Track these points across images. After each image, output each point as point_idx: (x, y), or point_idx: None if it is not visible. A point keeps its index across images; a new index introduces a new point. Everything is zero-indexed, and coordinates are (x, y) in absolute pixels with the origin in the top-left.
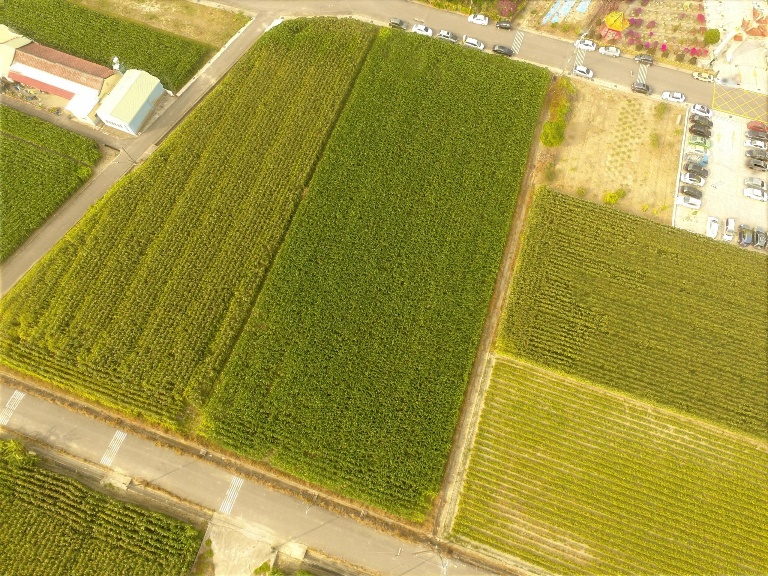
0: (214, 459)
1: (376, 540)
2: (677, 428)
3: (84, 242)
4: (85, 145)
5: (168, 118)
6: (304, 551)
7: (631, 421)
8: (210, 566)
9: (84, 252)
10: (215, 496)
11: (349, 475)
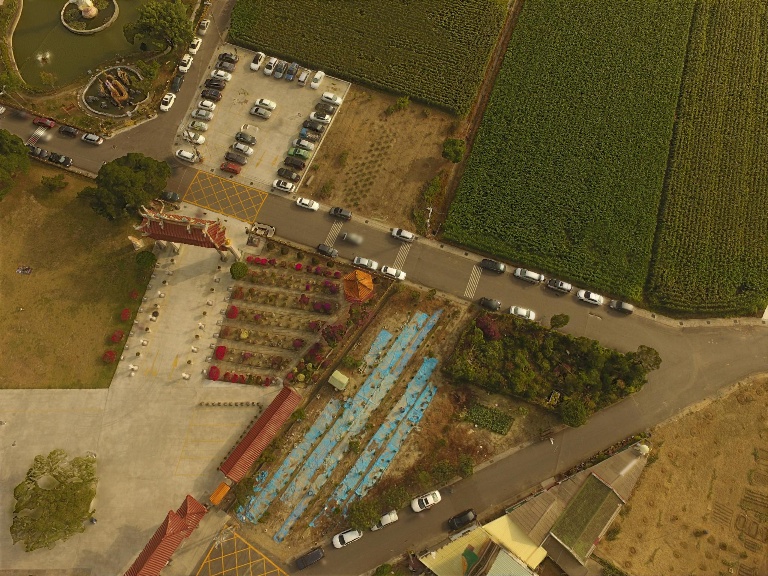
0: None
1: None
2: None
3: None
4: None
5: None
6: None
7: None
8: None
9: None
10: None
11: None
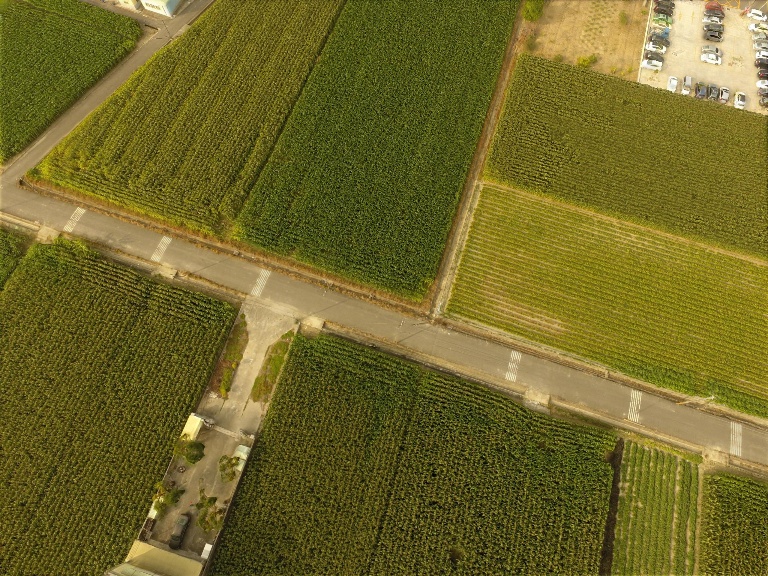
0: (245, 258)
1: (382, 315)
2: (638, 236)
3: (131, 96)
4: (129, 22)
5: (199, 4)
6: (322, 323)
7: (599, 230)
8: (244, 332)
9: (131, 102)
10: (247, 283)
11: (359, 265)
